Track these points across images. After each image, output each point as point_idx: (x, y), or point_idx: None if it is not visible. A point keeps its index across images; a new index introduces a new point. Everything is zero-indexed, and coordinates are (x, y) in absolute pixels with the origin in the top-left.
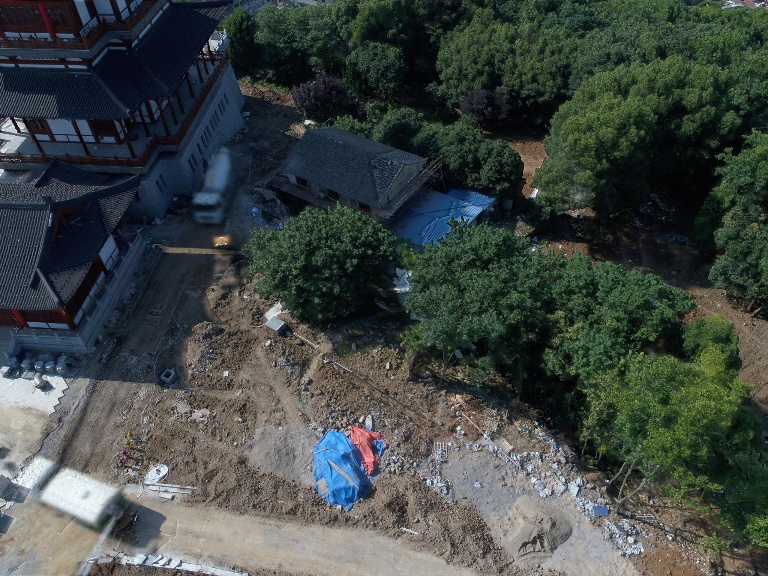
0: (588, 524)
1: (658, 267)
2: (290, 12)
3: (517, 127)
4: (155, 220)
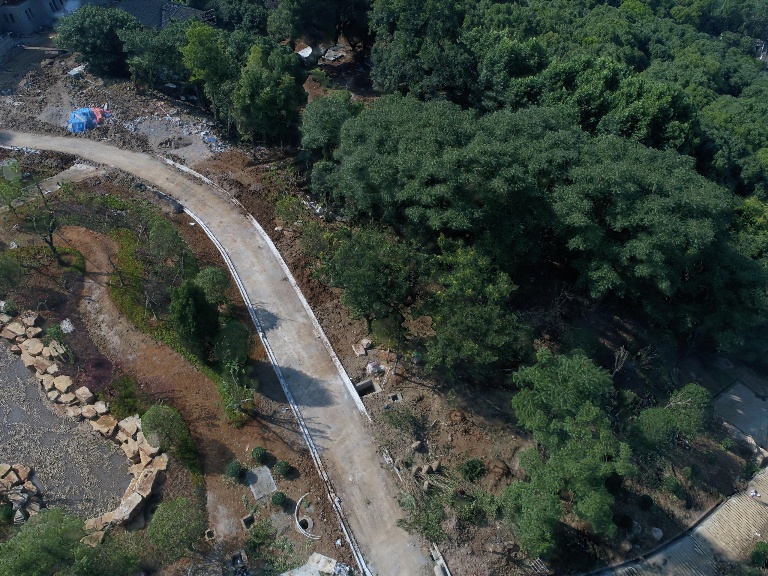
0: (201, 142)
1: (353, 86)
2: None
3: None
4: (24, 35)
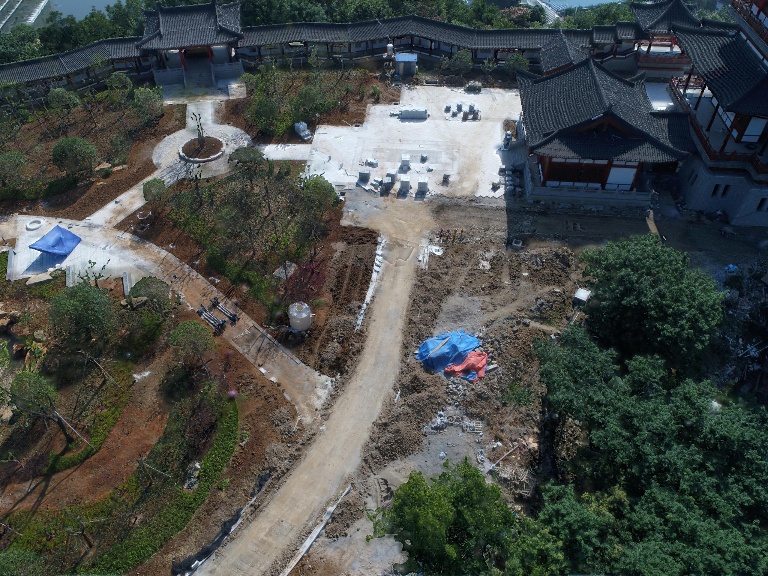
0: None
1: None
2: None
3: None
4: (683, 206)
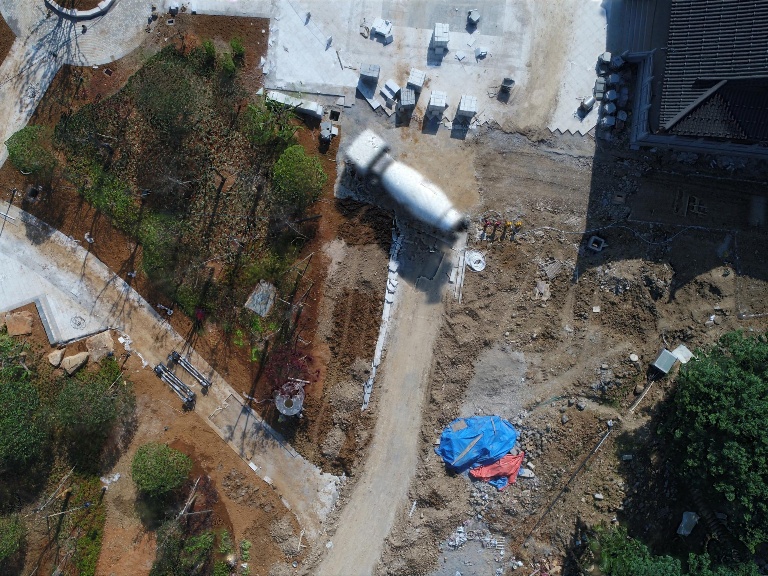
0: None
1: None
2: None
3: None
4: None
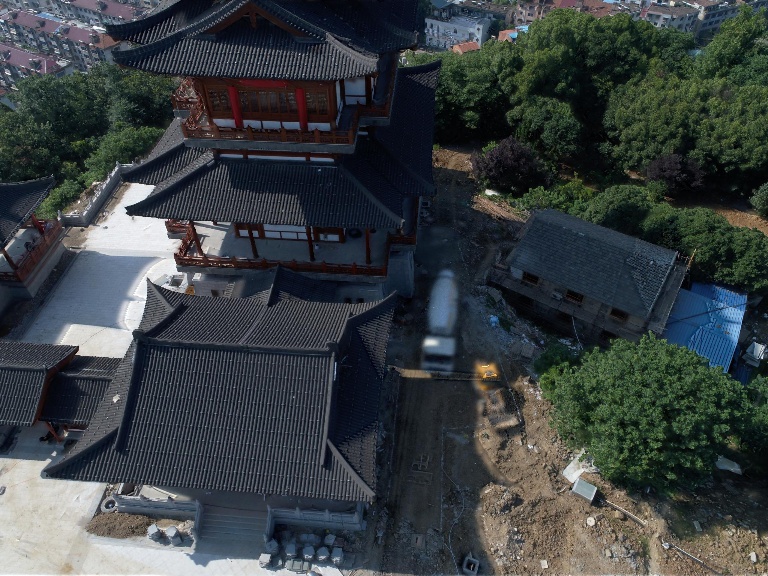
0: None
1: None
2: (442, 61)
3: (701, 193)
4: None
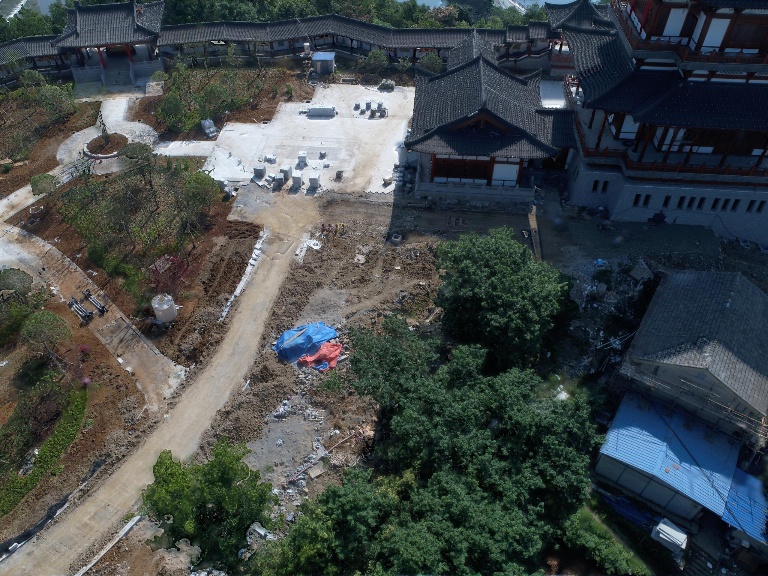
0: None
1: None
2: None
3: None
4: (567, 201)
